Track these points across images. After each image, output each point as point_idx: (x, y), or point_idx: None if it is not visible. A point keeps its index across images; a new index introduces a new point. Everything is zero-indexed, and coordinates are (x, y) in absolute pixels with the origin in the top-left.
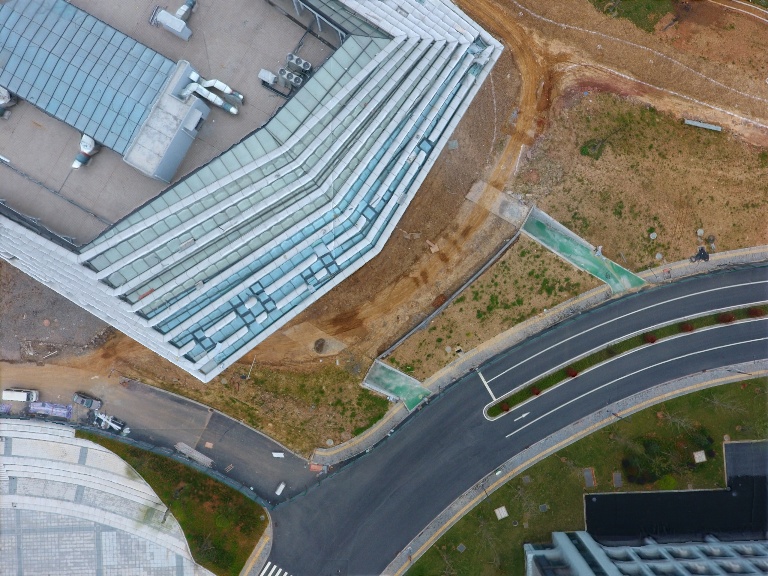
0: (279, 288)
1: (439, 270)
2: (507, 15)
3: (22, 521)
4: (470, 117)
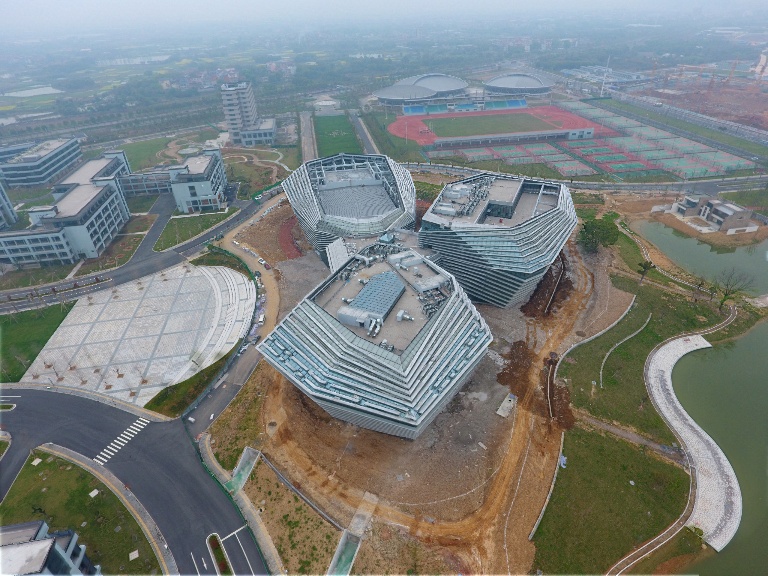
0: (295, 362)
1: (317, 482)
2: (501, 506)
3: (204, 330)
4: (420, 486)
